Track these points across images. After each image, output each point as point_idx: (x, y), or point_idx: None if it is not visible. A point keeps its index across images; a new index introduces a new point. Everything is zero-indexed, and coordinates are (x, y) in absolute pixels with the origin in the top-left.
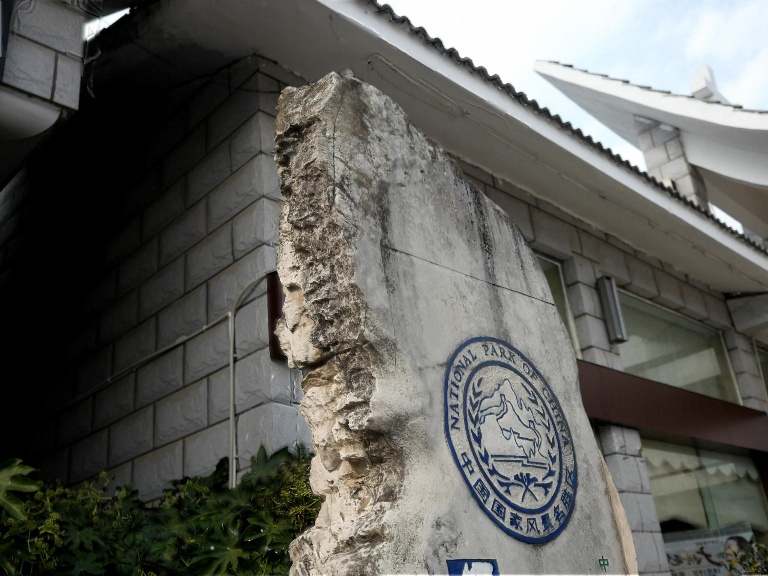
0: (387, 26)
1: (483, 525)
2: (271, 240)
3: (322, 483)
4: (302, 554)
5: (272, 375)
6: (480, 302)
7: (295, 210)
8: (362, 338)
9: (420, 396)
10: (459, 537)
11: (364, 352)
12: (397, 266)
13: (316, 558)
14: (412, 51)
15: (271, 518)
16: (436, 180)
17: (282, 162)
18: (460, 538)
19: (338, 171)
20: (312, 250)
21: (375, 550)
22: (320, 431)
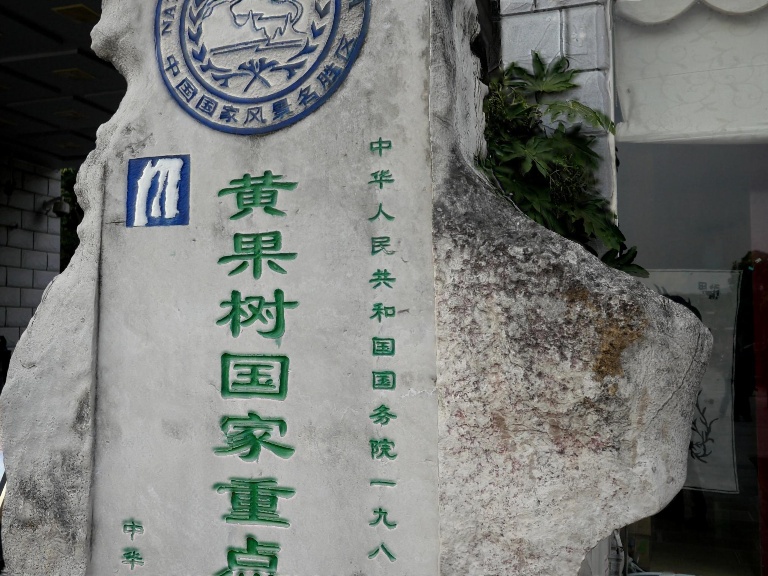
0: None
1: (180, 123)
2: None
3: None
4: None
5: None
6: None
7: None
8: None
9: (129, 11)
10: (149, 138)
11: None
12: None
13: None
14: None
15: None
16: None
17: None
18: (150, 139)
19: None
20: None
21: None
22: None
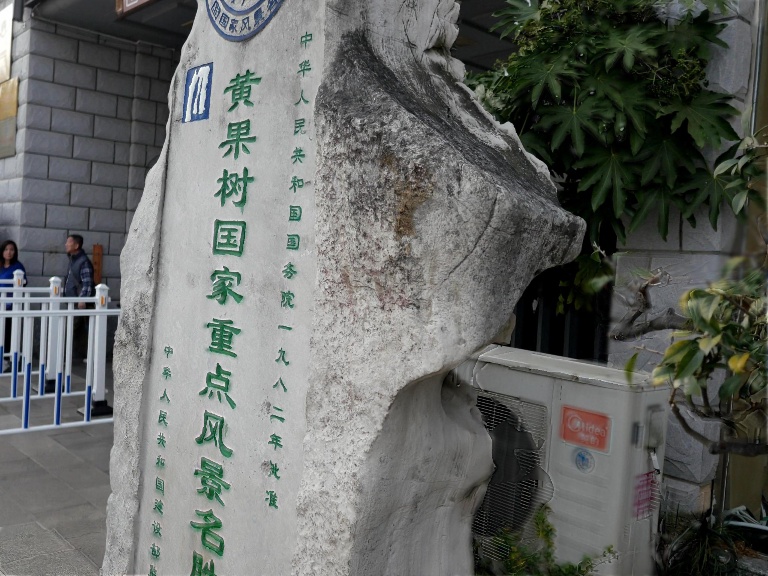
0: None
1: (211, 38)
2: None
3: None
4: None
5: None
6: None
7: None
8: None
9: None
10: (197, 52)
11: None
12: None
13: None
14: None
15: None
16: None
17: None
18: None
19: None
20: None
21: None
22: None
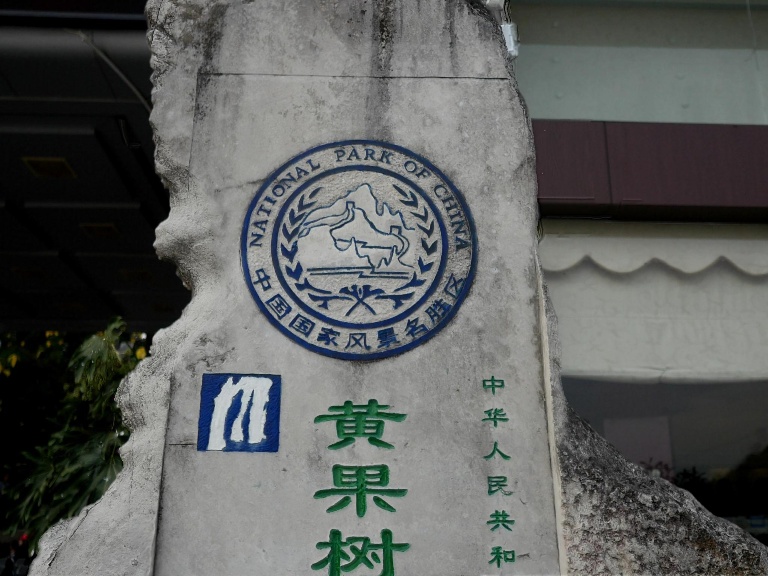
0: None
1: (269, 341)
2: None
3: None
4: None
5: None
6: (348, 103)
7: None
8: (156, 172)
9: (210, 218)
10: (229, 352)
11: None
12: (216, 90)
13: None
14: None
15: None
16: None
17: None
18: (230, 353)
19: (162, 12)
20: None
21: None
22: None
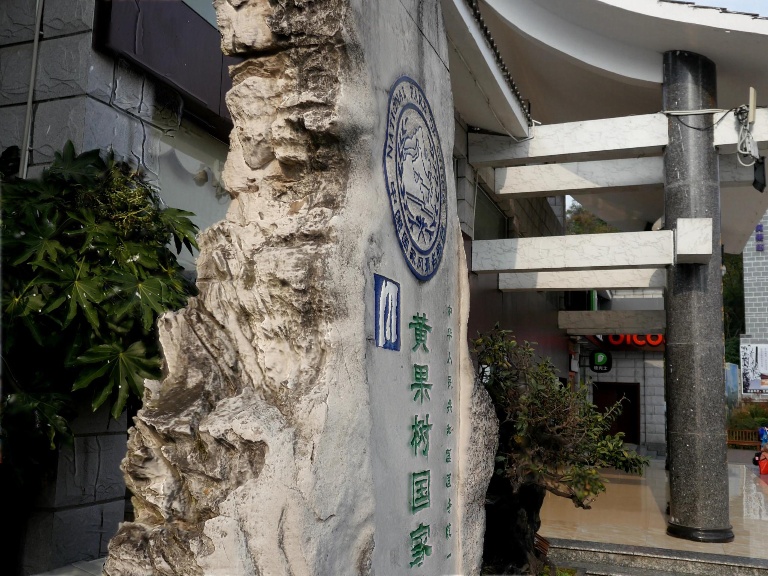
0: None
1: (396, 251)
2: None
3: (238, 180)
4: (215, 244)
5: (91, 65)
6: (413, 43)
7: None
8: (338, 36)
9: (373, 115)
10: (382, 256)
11: (332, 53)
12: None
13: (237, 249)
14: None
15: (93, 216)
16: None
17: None
18: (383, 257)
19: None
20: None
21: (324, 249)
22: (256, 124)
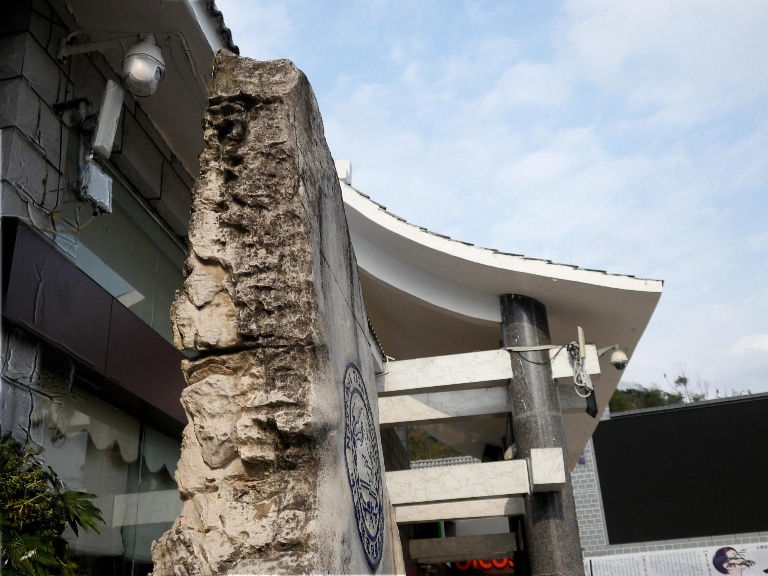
0: (203, 12)
1: (359, 546)
2: (15, 179)
3: (195, 480)
4: (175, 556)
5: None
6: (351, 329)
7: (245, 183)
8: (309, 339)
9: (337, 410)
10: (351, 555)
11: (300, 353)
12: (326, 275)
13: (203, 562)
14: (215, 47)
15: None
16: (336, 201)
17: (219, 125)
18: (351, 557)
19: (301, 162)
20: (257, 231)
21: (306, 560)
22: (219, 423)
